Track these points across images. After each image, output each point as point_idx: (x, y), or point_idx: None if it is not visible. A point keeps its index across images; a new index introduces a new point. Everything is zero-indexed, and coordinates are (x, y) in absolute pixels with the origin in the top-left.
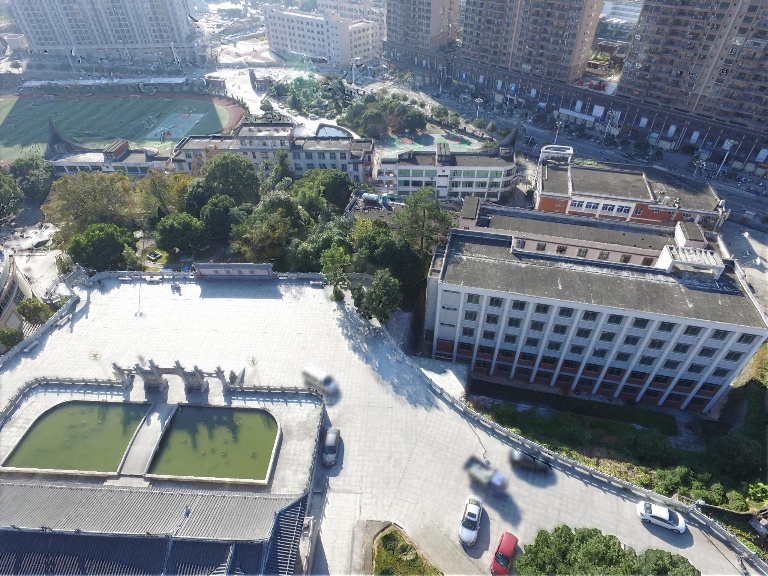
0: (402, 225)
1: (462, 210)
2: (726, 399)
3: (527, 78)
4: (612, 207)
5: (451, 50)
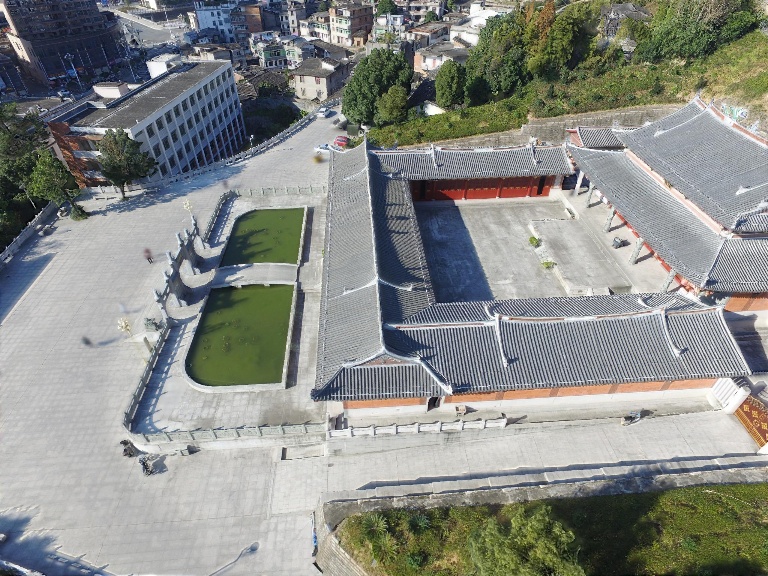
0: (7, 149)
1: None
2: None
3: None
4: None
5: None
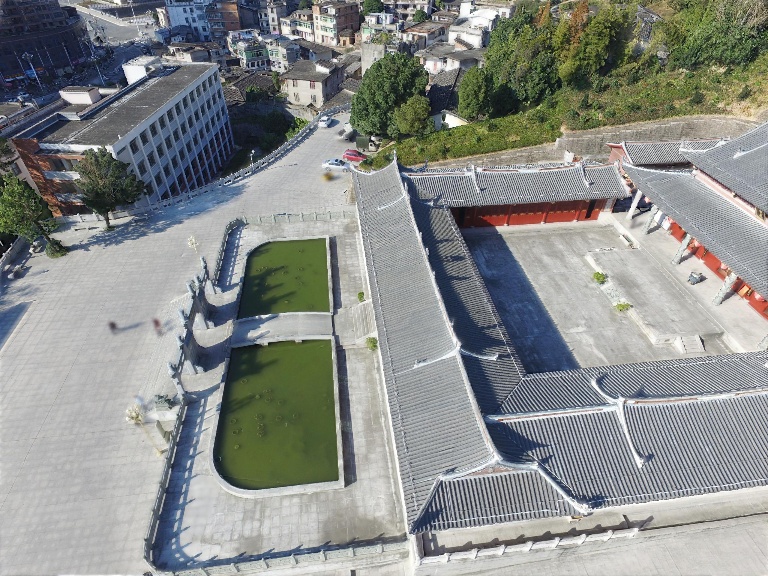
0: None
1: None
2: None
3: None
4: None
5: None
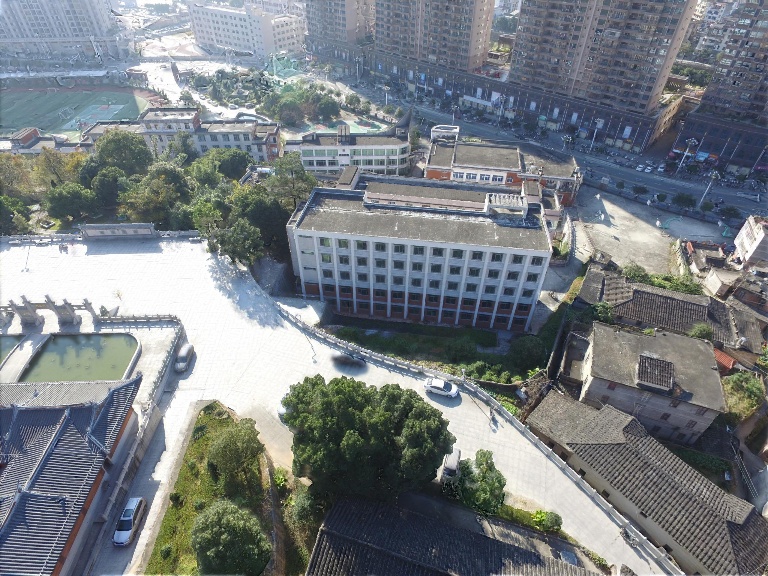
0: (273, 187)
1: (340, 177)
2: (546, 320)
3: (434, 68)
4: (488, 177)
5: (368, 43)
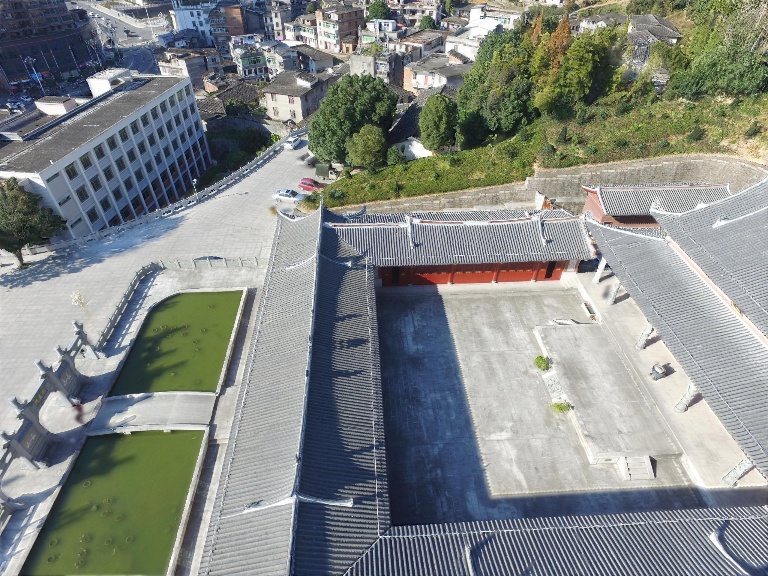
0: None
1: None
2: None
3: None
4: None
5: None
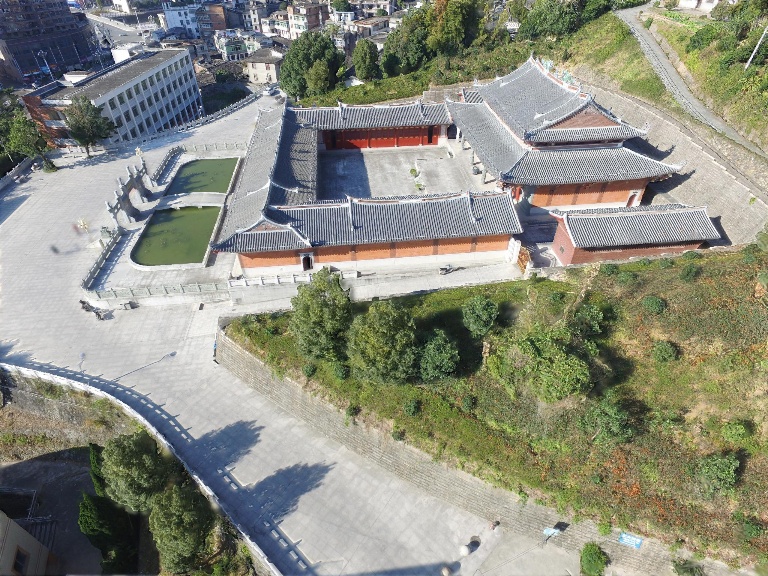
0: None
1: None
2: None
3: None
4: None
5: None
